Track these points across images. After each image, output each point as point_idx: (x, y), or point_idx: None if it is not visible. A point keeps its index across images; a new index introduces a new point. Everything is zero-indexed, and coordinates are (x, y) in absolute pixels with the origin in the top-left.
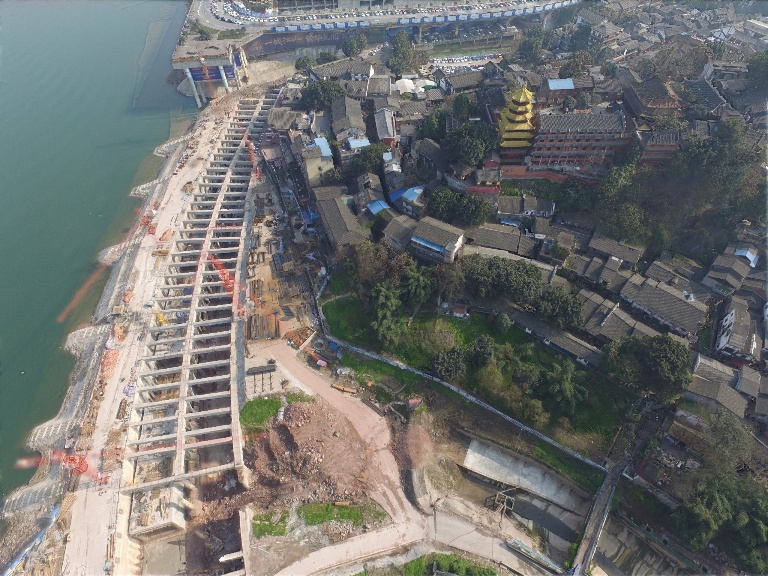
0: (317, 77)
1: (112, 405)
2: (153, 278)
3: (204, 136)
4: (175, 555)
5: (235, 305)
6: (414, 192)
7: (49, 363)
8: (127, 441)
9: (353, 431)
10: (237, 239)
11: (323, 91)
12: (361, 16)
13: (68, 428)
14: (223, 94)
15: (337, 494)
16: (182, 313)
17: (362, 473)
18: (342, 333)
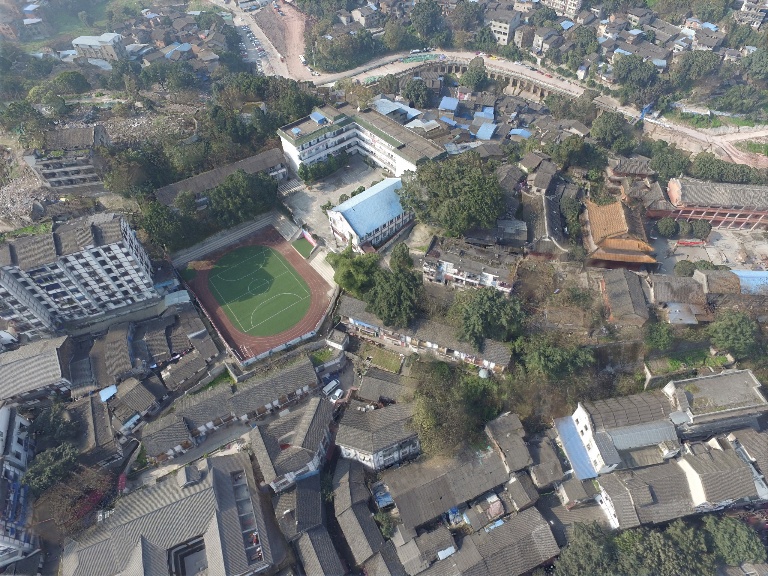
0: None
1: None
2: None
3: None
4: None
5: None
6: None
7: None
8: None
9: None
10: None
11: None
12: None
13: None
14: None
15: (766, 156)
16: None
17: (756, 161)
18: None
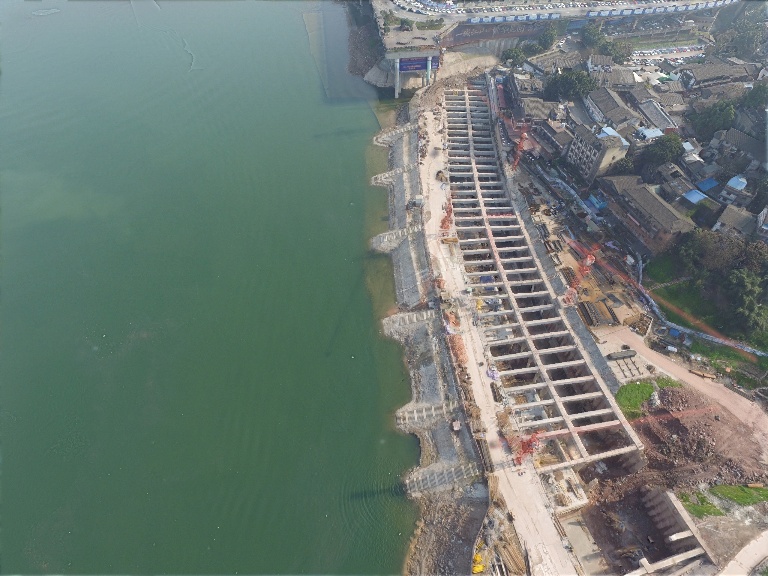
0: (538, 68)
1: (484, 388)
2: (456, 265)
3: (429, 126)
4: (582, 535)
5: (552, 292)
6: (740, 181)
7: (377, 348)
8: (517, 423)
9: (732, 415)
10: (517, 228)
11: (578, 82)
12: (545, 8)
13: (446, 411)
14: (415, 85)
15: (747, 476)
16: (491, 300)
17: (761, 456)
18: (683, 320)
